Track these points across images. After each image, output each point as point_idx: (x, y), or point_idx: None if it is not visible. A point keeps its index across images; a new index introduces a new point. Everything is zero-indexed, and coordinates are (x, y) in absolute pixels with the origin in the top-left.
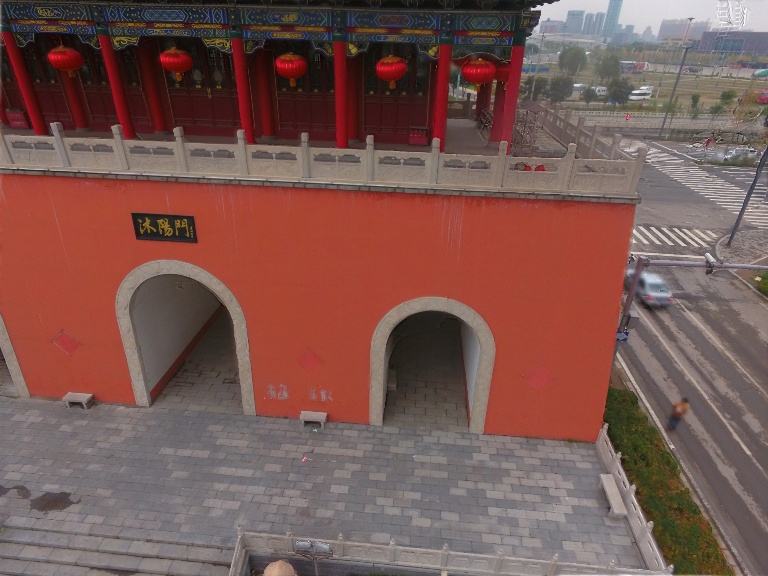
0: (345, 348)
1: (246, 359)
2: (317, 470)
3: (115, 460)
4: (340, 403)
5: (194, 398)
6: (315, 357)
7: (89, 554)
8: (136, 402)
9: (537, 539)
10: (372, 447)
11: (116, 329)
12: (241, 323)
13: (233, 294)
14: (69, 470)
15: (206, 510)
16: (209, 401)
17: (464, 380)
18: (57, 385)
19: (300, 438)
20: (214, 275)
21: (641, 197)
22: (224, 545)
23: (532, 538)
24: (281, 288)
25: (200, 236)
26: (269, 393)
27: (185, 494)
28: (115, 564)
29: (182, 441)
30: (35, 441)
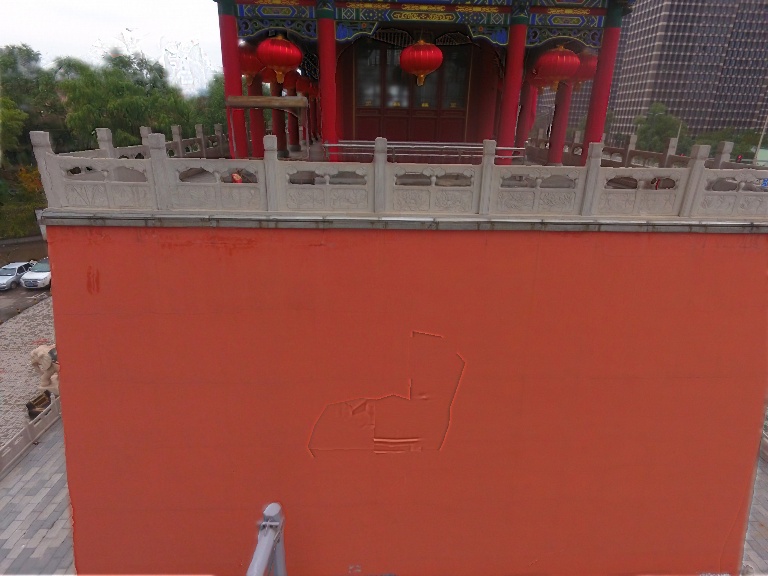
0: None
1: None
2: None
3: None
4: None
5: None
6: None
7: None
8: None
9: (1, 508)
10: None
11: None
12: None
13: None
14: None
15: None
16: None
17: None
18: None
19: None
20: None
21: (37, 214)
22: None
23: (6, 504)
24: None
25: None
26: None
27: None
28: None
29: None
30: None
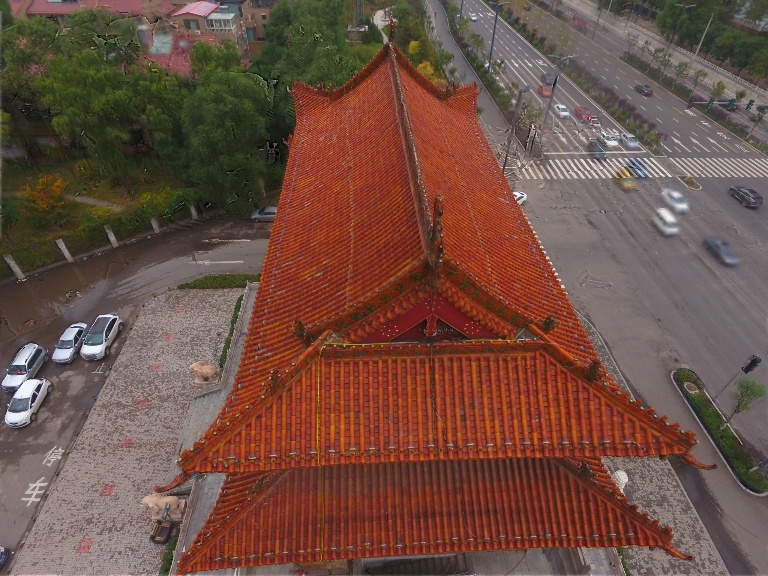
0: None
1: None
2: None
3: None
4: None
5: None
6: None
7: None
8: None
9: None
10: None
11: None
12: None
13: None
14: None
15: None
16: None
17: None
18: None
19: None
20: None
21: None
22: None
23: None
24: None
25: None
26: None
27: None
28: None
29: None
30: None
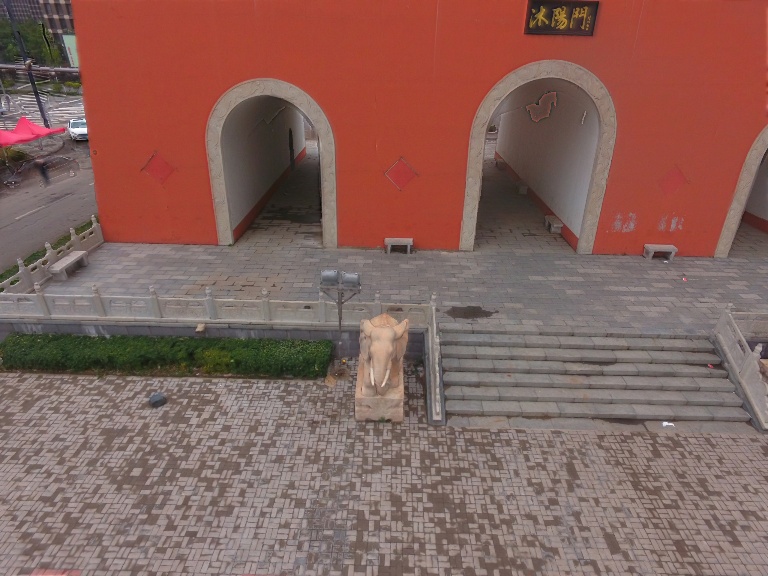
0: (715, 163)
1: (601, 183)
2: (708, 285)
3: (492, 284)
4: (689, 232)
5: (510, 245)
6: (680, 176)
7: (552, 350)
8: (459, 246)
9: None
10: (739, 270)
11: (463, 153)
12: (610, 137)
13: (612, 100)
14: (454, 292)
15: (639, 313)
16: (529, 246)
17: (761, 228)
18: (372, 231)
19: (659, 267)
20: (598, 77)
21: None
22: (694, 334)
23: None
24: (668, 90)
25: (598, 27)
26: (614, 225)
27: (600, 304)
28: (590, 355)
29: (542, 271)
30: (387, 275)
